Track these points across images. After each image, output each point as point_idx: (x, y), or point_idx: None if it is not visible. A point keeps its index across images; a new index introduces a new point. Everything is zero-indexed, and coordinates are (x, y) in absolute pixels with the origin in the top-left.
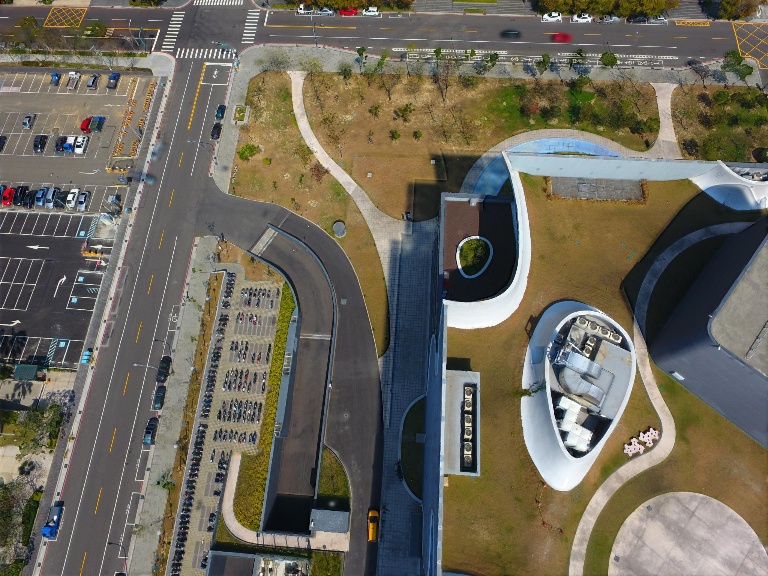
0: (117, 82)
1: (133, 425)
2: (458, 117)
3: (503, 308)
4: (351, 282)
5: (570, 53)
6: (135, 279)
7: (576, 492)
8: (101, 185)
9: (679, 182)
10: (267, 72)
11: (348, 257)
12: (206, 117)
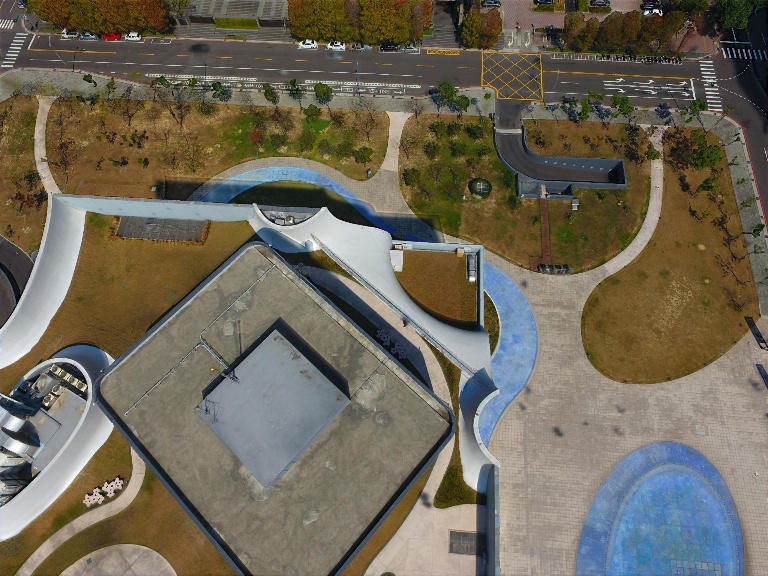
0: None
1: None
2: (192, 144)
3: (4, 353)
4: None
5: (317, 81)
6: None
7: (10, 545)
8: None
9: (240, 223)
10: (17, 96)
11: None
12: None
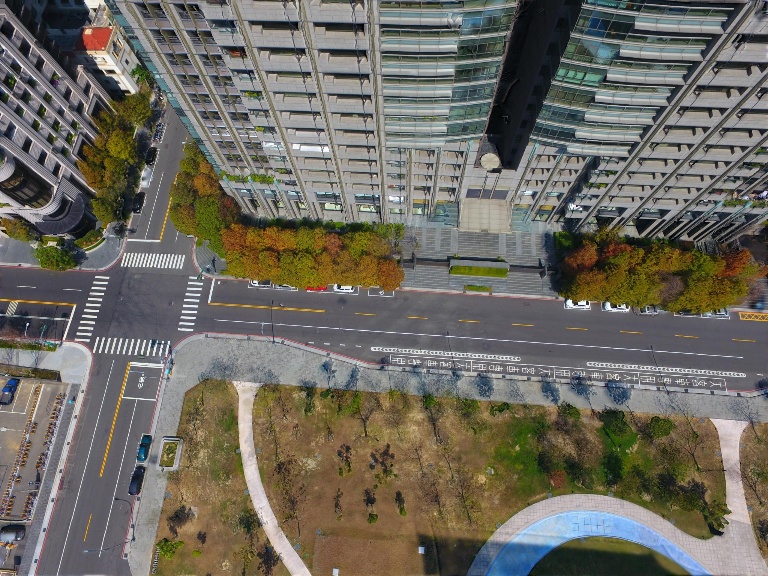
0: (15, 392)
1: None
2: (456, 468)
3: None
4: None
5: (603, 363)
6: None
7: None
8: None
9: None
10: (208, 382)
11: None
12: (125, 455)
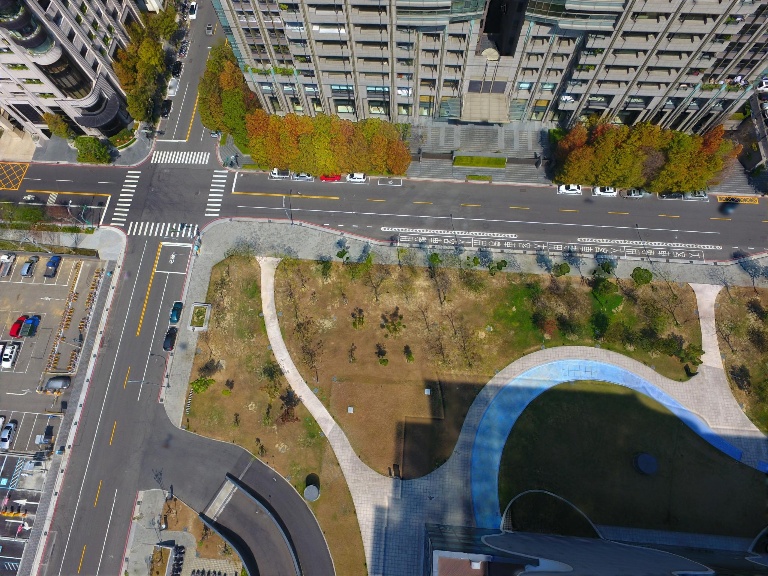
0: (57, 267)
1: None
2: (458, 326)
3: None
4: (325, 568)
5: (592, 238)
6: (63, 551)
7: None
8: (30, 412)
9: None
10: (233, 258)
11: (322, 531)
12: (159, 318)
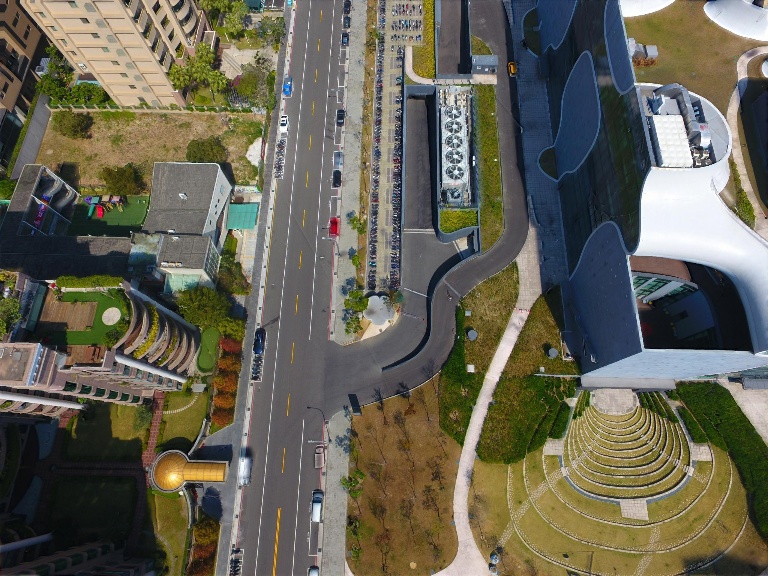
0: None
1: (331, 37)
2: None
3: None
4: None
5: None
6: None
7: None
8: None
9: None
10: None
11: None
12: None
